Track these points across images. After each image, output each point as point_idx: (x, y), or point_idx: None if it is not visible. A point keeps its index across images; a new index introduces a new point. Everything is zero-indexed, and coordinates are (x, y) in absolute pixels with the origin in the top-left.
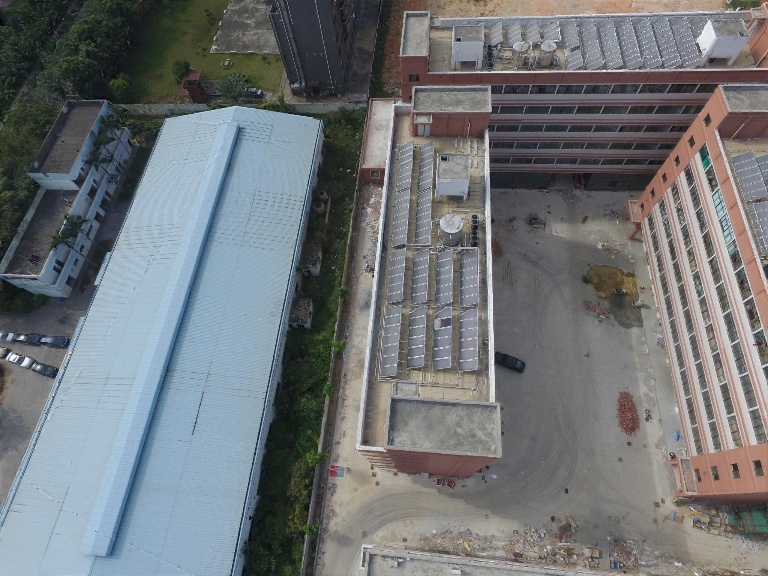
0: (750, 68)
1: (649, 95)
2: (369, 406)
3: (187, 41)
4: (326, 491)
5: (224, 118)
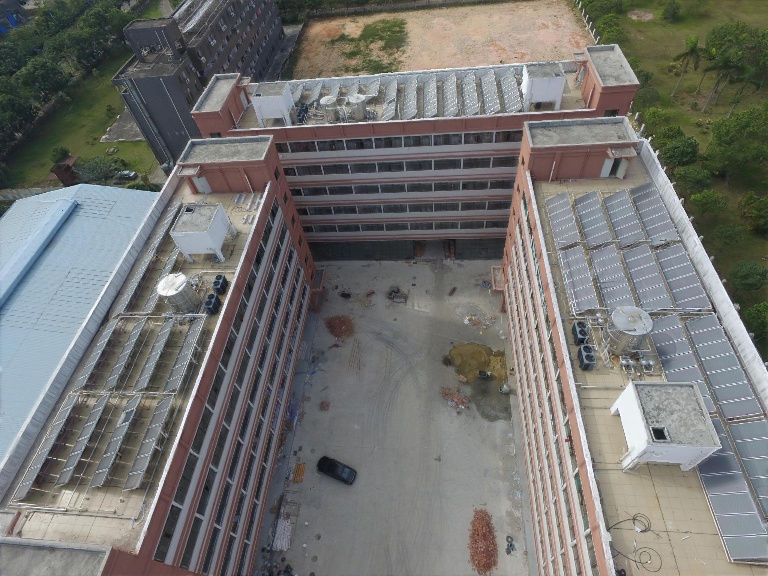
0: (574, 109)
1: (477, 145)
2: None
3: (82, 133)
4: None
5: (66, 196)
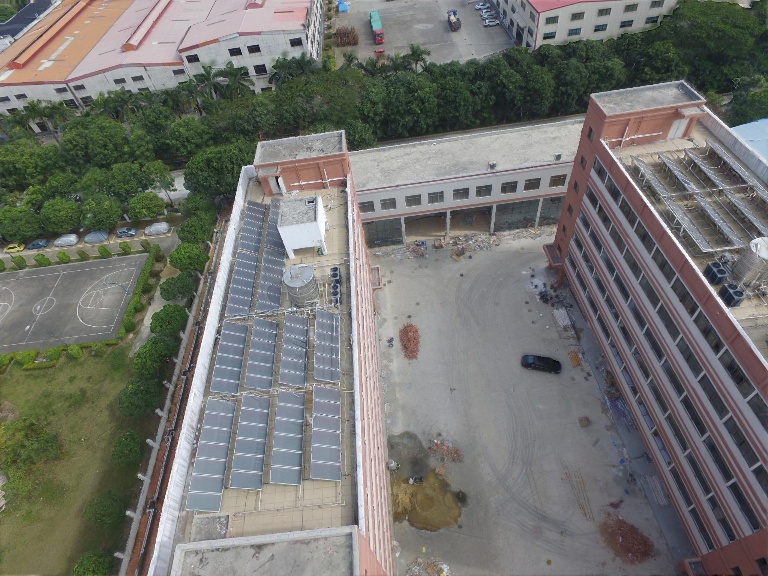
0: None
1: None
2: (709, 133)
3: None
4: None
5: None
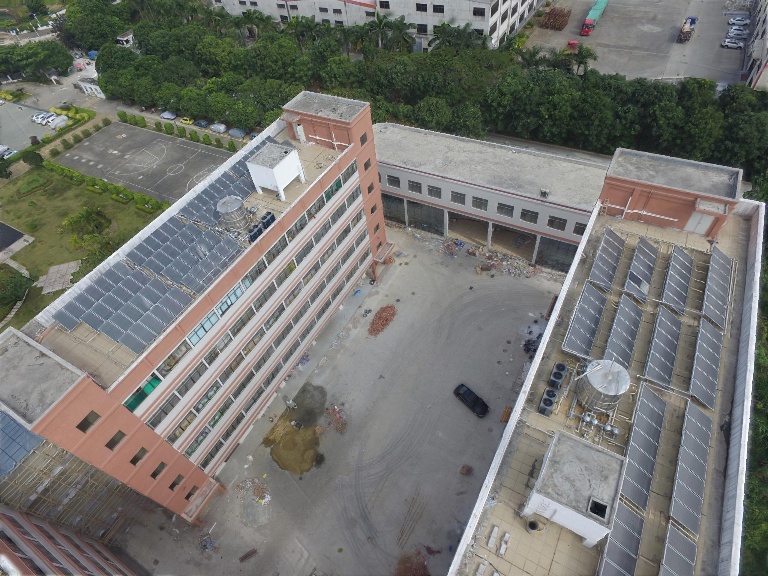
0: None
1: None
2: (744, 244)
3: None
4: None
5: None
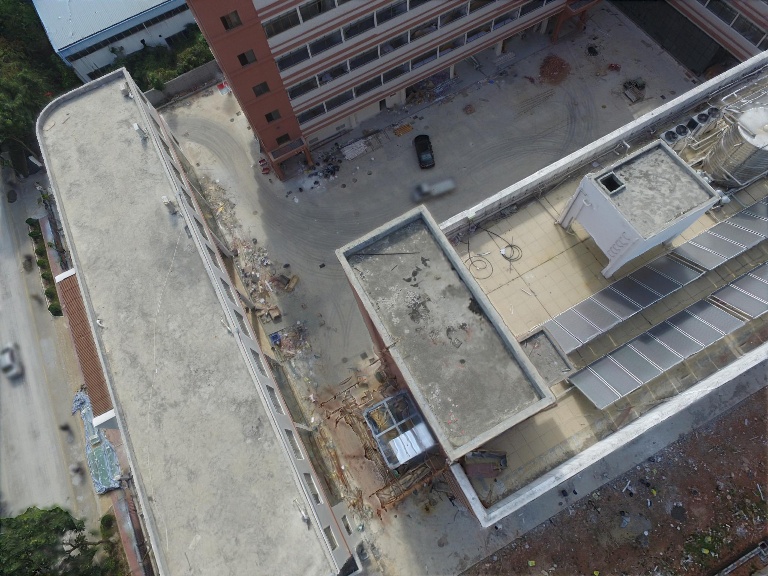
0: None
1: None
2: None
3: None
4: (203, 90)
5: None
